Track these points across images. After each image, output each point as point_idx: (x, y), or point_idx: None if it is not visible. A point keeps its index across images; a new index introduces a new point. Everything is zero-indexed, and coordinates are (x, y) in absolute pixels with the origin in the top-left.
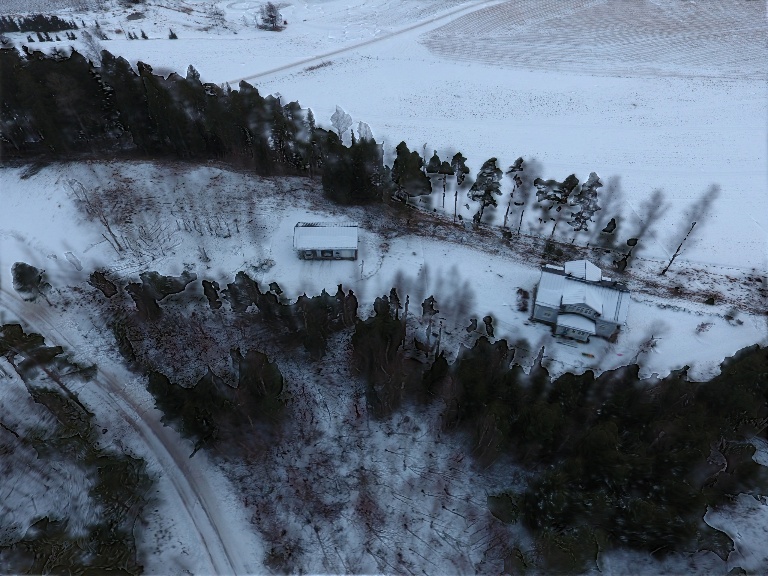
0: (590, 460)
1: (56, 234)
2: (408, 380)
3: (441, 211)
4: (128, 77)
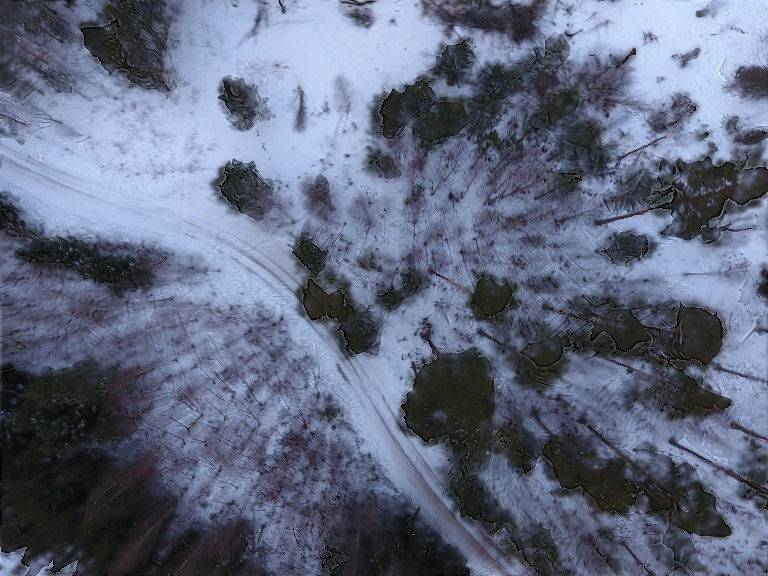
0: None
1: None
2: (195, 565)
3: None
4: None
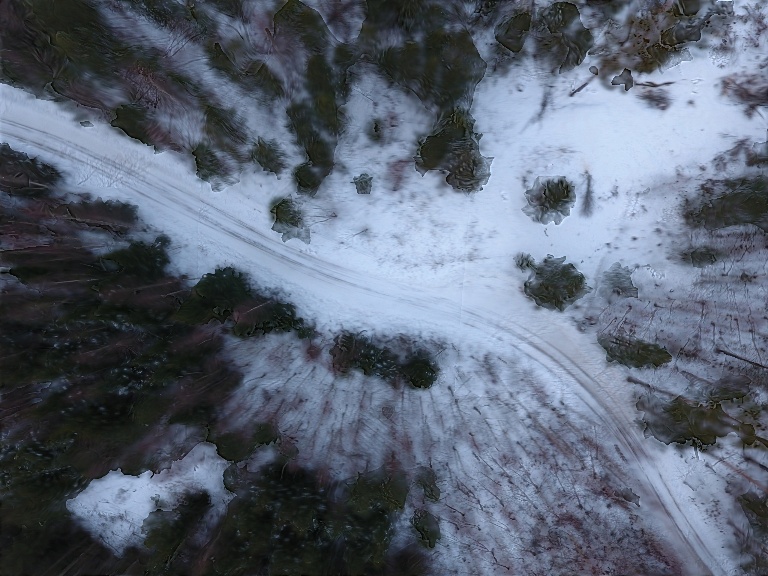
0: (325, 561)
1: None
2: None
3: None
4: None
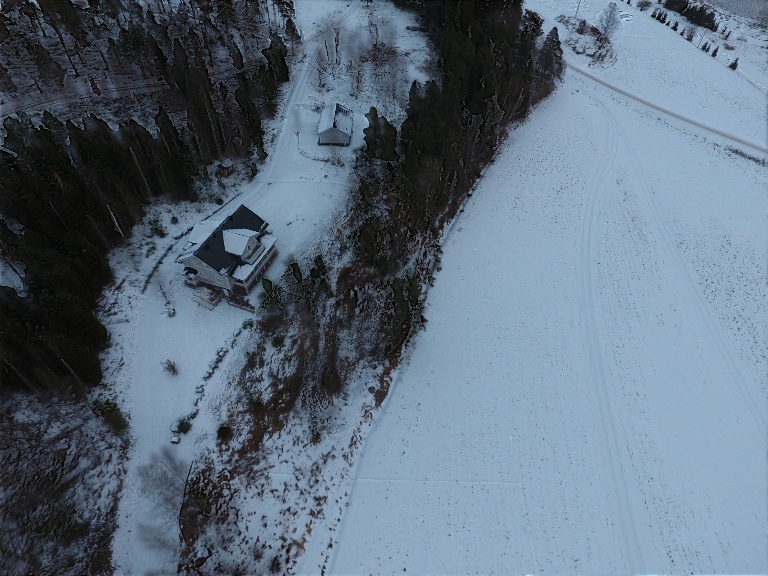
0: None
1: (352, 45)
2: None
3: (445, 242)
4: (480, 5)
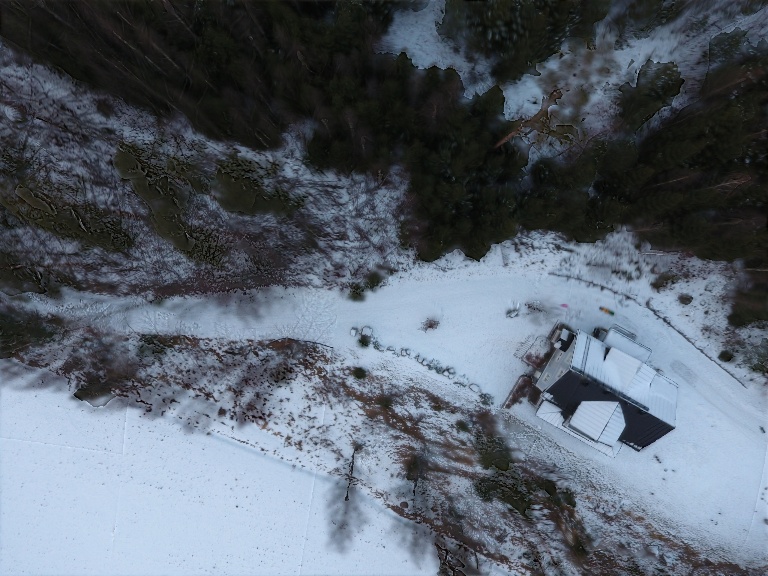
0: None
1: None
2: None
3: None
4: None
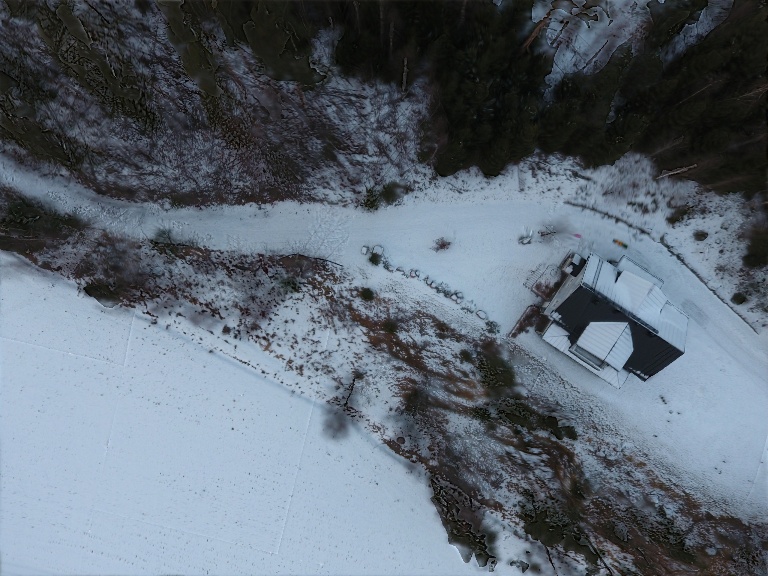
0: None
1: None
2: None
3: None
4: None
